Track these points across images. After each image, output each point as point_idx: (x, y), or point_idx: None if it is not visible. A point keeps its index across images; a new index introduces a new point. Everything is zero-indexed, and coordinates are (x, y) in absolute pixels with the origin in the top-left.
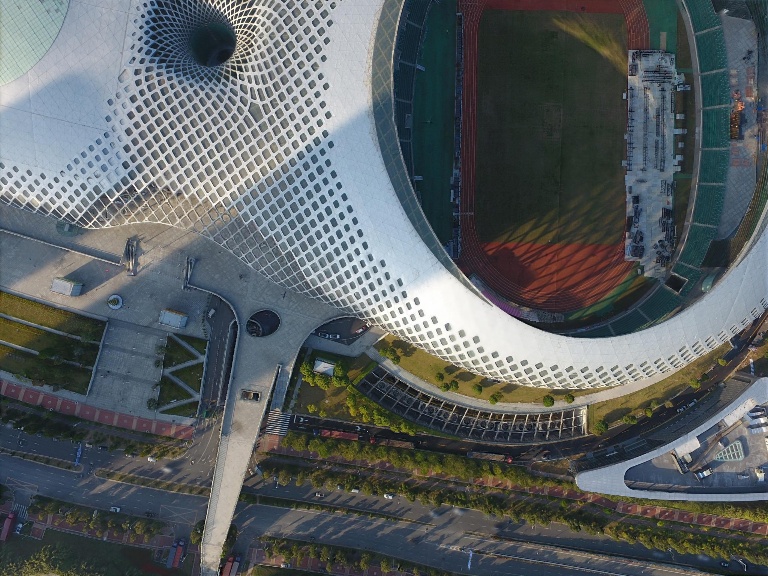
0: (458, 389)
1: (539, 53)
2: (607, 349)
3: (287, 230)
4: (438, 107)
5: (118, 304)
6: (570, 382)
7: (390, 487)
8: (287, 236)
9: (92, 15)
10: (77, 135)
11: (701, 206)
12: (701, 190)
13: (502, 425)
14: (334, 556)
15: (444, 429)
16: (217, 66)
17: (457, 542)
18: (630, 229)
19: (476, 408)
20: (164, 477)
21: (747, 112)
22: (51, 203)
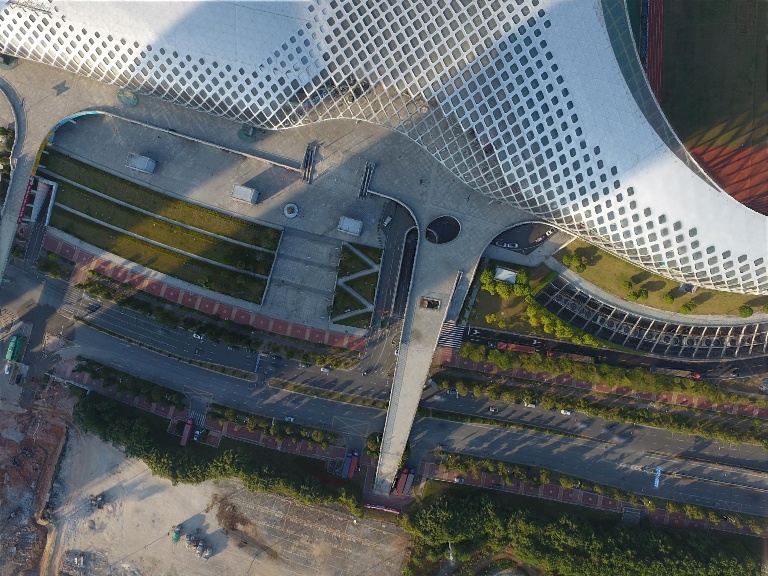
0: (644, 300)
1: None
2: None
3: (490, 120)
4: None
5: (294, 212)
6: None
7: (568, 403)
8: (490, 127)
9: None
10: (279, 26)
11: None
12: None
13: (687, 340)
14: (512, 470)
15: None
16: None
17: (638, 461)
18: None
19: (663, 320)
20: (337, 388)
21: None
22: (246, 101)
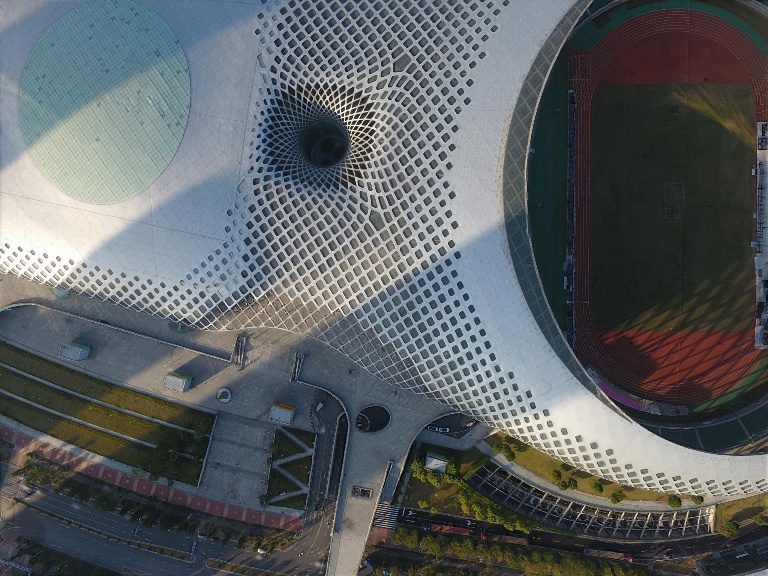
0: None
1: (658, 129)
2: (756, 465)
3: (408, 338)
4: (549, 190)
5: (227, 397)
6: (708, 492)
7: None
8: (407, 343)
9: (211, 126)
10: (197, 246)
11: None
12: None
13: (620, 521)
14: None
15: None
16: (332, 169)
17: None
18: (761, 315)
19: (594, 505)
20: (274, 568)
21: None
22: (169, 309)
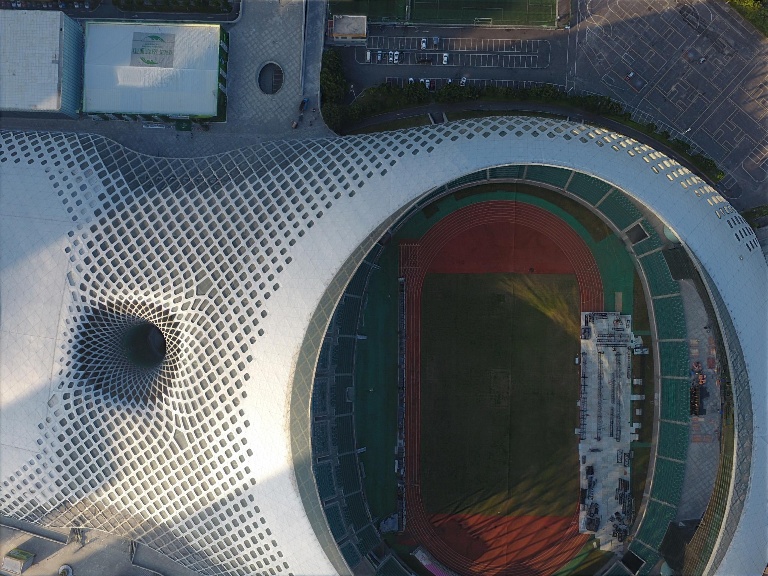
0: None
1: (485, 317)
2: None
3: (217, 548)
4: (381, 375)
5: (68, 574)
6: None
7: None
8: (217, 553)
9: (21, 343)
10: (11, 456)
11: (660, 481)
12: (660, 464)
13: None
14: None
15: None
16: (146, 378)
17: None
18: (584, 500)
19: None
20: None
21: (709, 385)
22: None
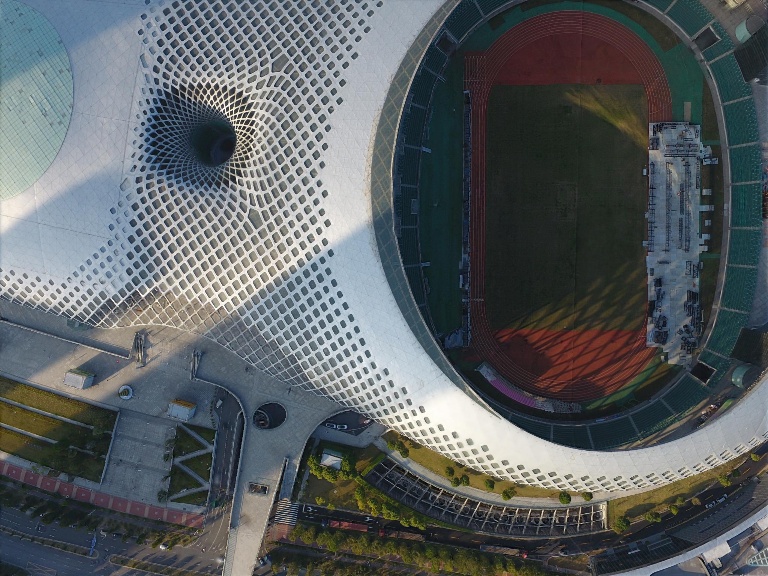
0: (469, 482)
1: (552, 129)
2: (625, 461)
3: (289, 335)
4: (445, 189)
5: (128, 394)
6: (586, 488)
7: None
8: (289, 341)
9: (94, 125)
10: (82, 243)
11: (730, 290)
12: (730, 272)
13: (516, 517)
14: None
15: (456, 519)
16: (217, 168)
17: None
18: (652, 314)
19: (488, 502)
20: (176, 564)
21: None
22: (60, 306)
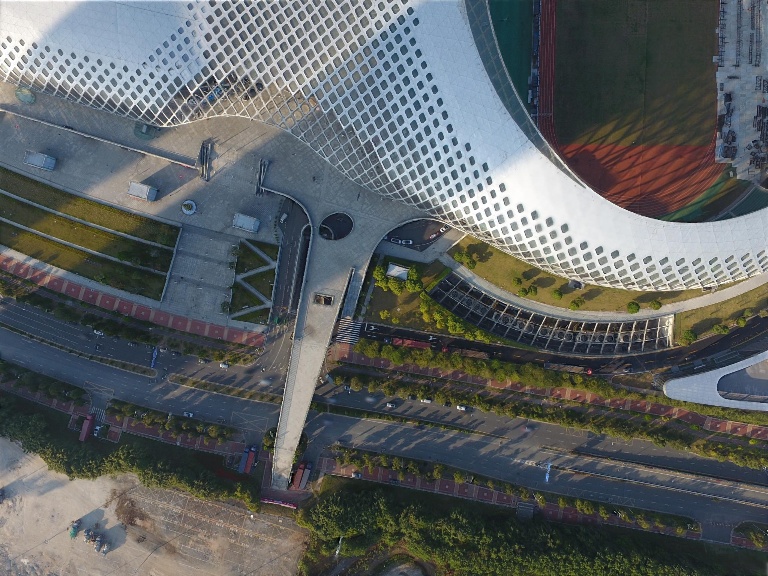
0: (535, 296)
1: None
2: (708, 236)
3: (367, 117)
4: (515, 5)
5: (192, 209)
6: (663, 278)
7: (463, 398)
8: (367, 124)
9: None
10: (160, 24)
11: None
12: None
13: (581, 336)
14: (406, 465)
15: (518, 341)
16: None
17: (532, 457)
18: (721, 129)
19: (554, 316)
20: (236, 384)
21: None
22: (132, 98)
